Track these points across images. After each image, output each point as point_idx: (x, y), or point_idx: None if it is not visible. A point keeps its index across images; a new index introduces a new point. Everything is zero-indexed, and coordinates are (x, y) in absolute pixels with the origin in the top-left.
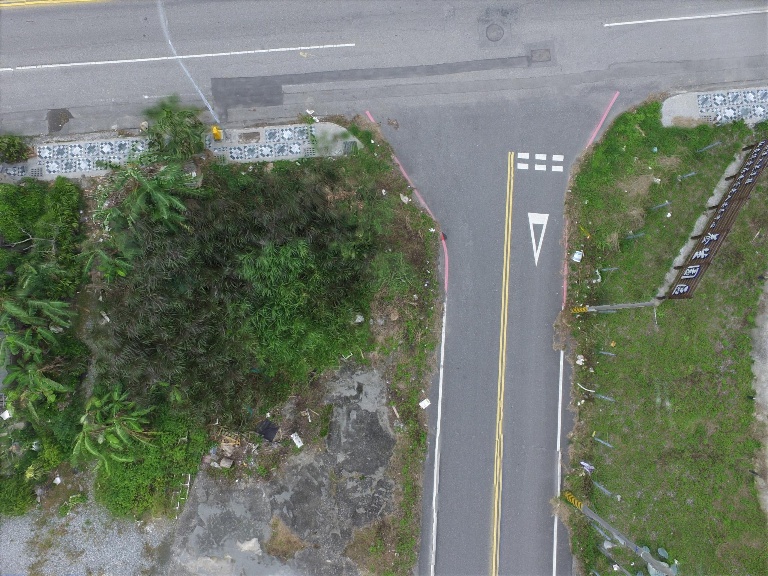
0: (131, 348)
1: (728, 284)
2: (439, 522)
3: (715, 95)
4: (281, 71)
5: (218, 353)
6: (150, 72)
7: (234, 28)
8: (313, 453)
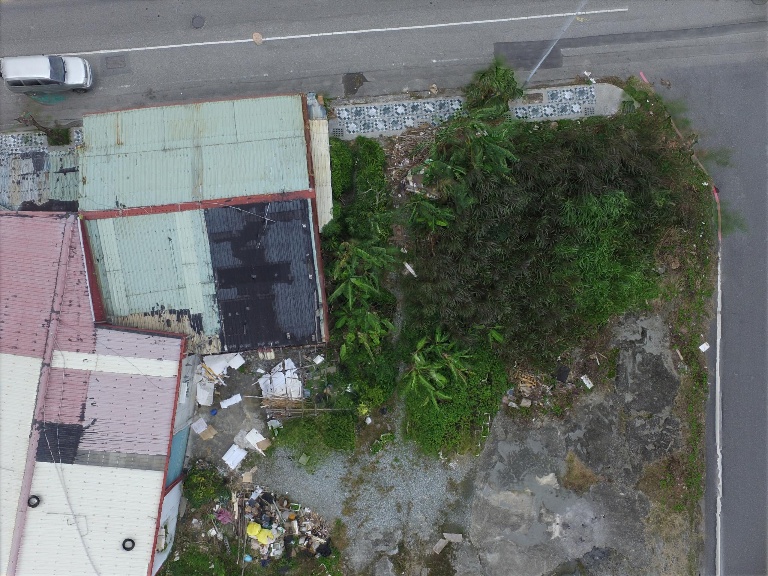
0: (463, 291)
1: None
2: (723, 457)
3: None
4: None
5: None
6: (437, 37)
7: None
8: (603, 394)
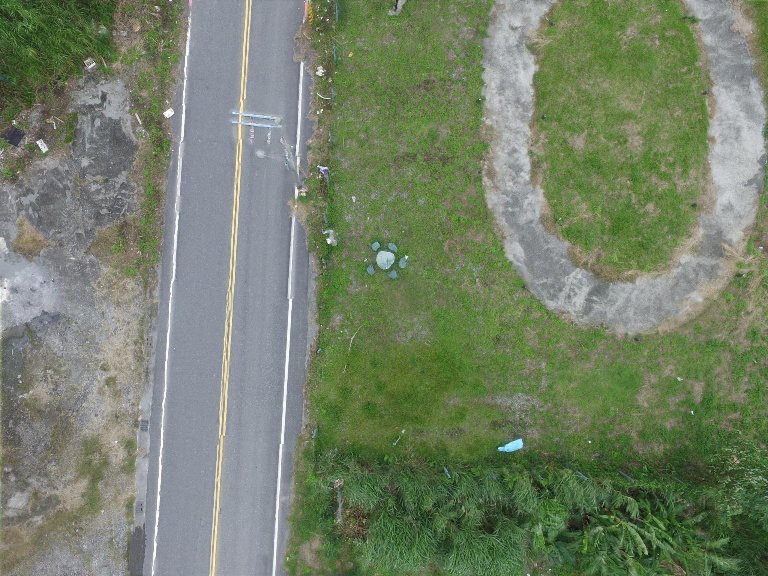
0: None
1: None
2: (181, 224)
3: None
4: None
5: None
6: None
7: None
8: (58, 158)
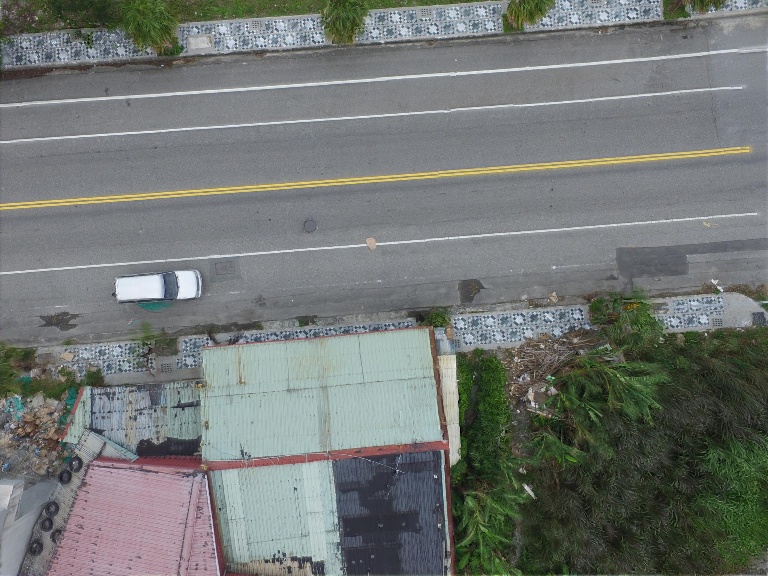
0: (598, 539)
1: None
2: None
3: None
4: (686, 241)
5: None
6: (557, 242)
7: (639, 198)
8: None
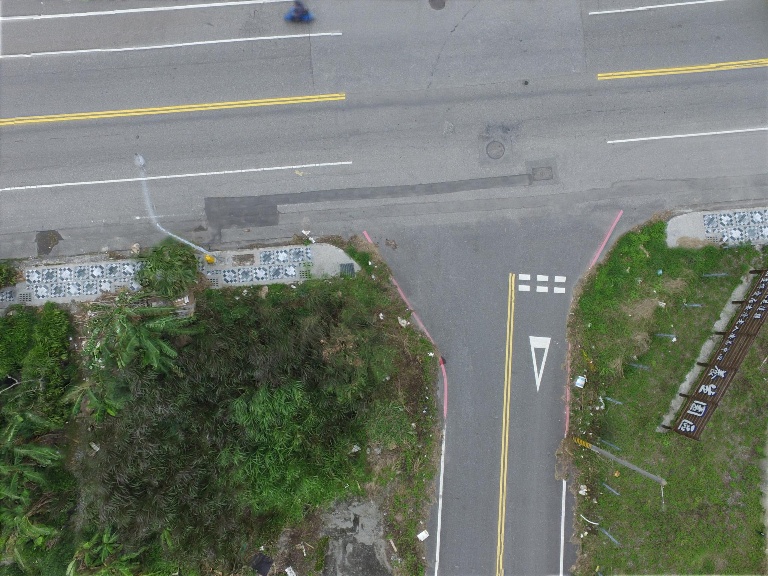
0: (120, 495)
1: (735, 412)
2: None
3: (721, 215)
4: (276, 191)
5: (210, 496)
6: (142, 192)
7: (228, 146)
8: None
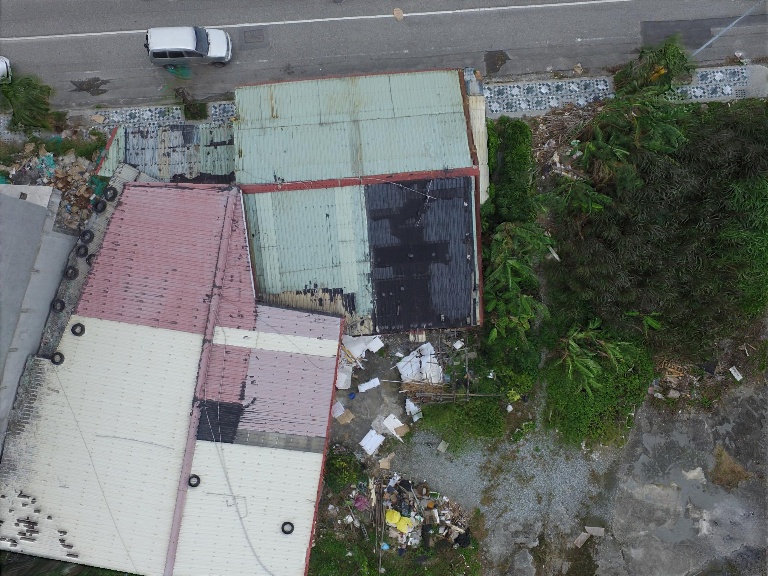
0: (624, 275)
1: None
2: None
3: None
4: (710, 14)
5: None
6: (582, 15)
7: None
8: (752, 386)
